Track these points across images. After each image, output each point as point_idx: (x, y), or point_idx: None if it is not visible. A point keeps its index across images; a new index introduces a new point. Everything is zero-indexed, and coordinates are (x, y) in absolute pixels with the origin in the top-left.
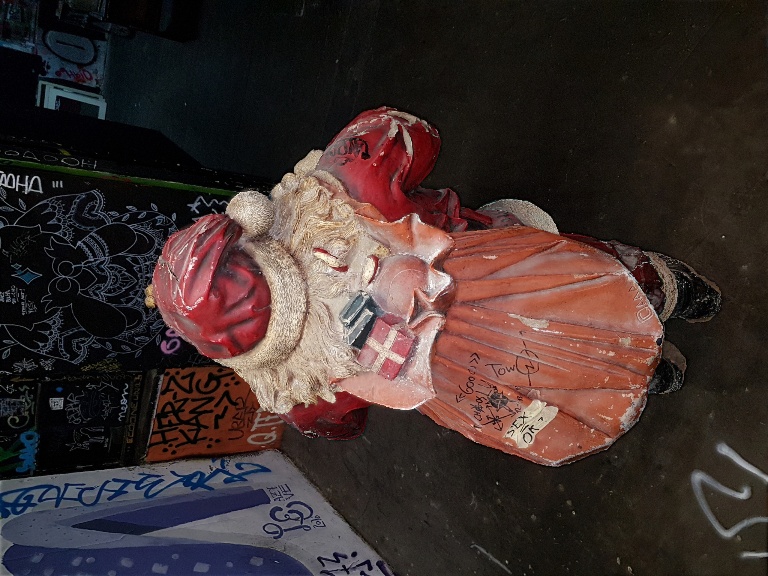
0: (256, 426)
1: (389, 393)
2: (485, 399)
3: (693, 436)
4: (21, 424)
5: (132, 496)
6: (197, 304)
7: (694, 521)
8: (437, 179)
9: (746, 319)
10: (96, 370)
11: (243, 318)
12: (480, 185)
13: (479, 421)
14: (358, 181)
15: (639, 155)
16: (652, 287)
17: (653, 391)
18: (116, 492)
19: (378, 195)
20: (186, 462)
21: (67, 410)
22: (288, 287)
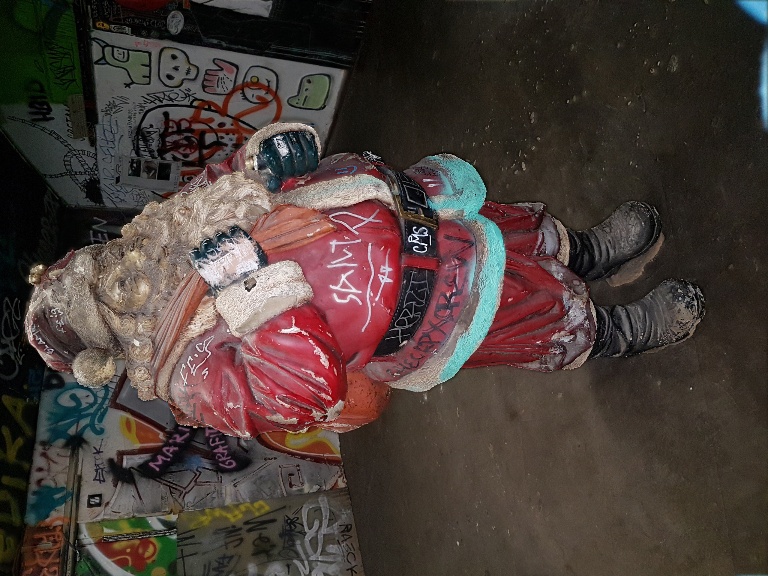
0: None
1: None
2: None
3: None
4: None
5: None
6: None
7: None
8: None
9: None
10: None
11: None
12: None
13: None
14: None
15: None
16: None
17: None
18: None
19: None
20: None
21: None
22: None
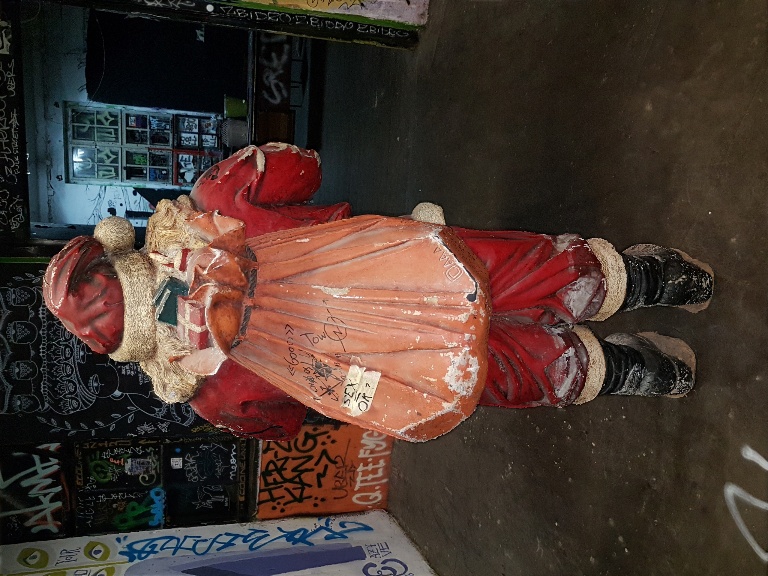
0: (359, 485)
1: (206, 363)
2: (311, 369)
3: (718, 443)
4: (150, 482)
5: (238, 548)
6: (61, 303)
7: (735, 546)
8: (474, 219)
9: (744, 297)
10: (205, 432)
11: (99, 312)
12: (507, 216)
13: (316, 393)
14: (204, 197)
15: (627, 150)
16: (588, 270)
17: (651, 391)
18: (225, 544)
19: (221, 206)
20: (294, 520)
21: (186, 469)
22: (135, 285)
